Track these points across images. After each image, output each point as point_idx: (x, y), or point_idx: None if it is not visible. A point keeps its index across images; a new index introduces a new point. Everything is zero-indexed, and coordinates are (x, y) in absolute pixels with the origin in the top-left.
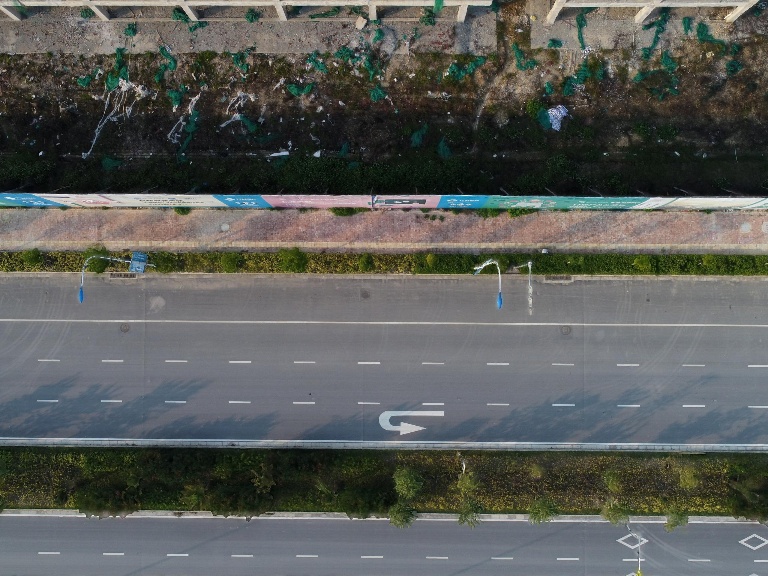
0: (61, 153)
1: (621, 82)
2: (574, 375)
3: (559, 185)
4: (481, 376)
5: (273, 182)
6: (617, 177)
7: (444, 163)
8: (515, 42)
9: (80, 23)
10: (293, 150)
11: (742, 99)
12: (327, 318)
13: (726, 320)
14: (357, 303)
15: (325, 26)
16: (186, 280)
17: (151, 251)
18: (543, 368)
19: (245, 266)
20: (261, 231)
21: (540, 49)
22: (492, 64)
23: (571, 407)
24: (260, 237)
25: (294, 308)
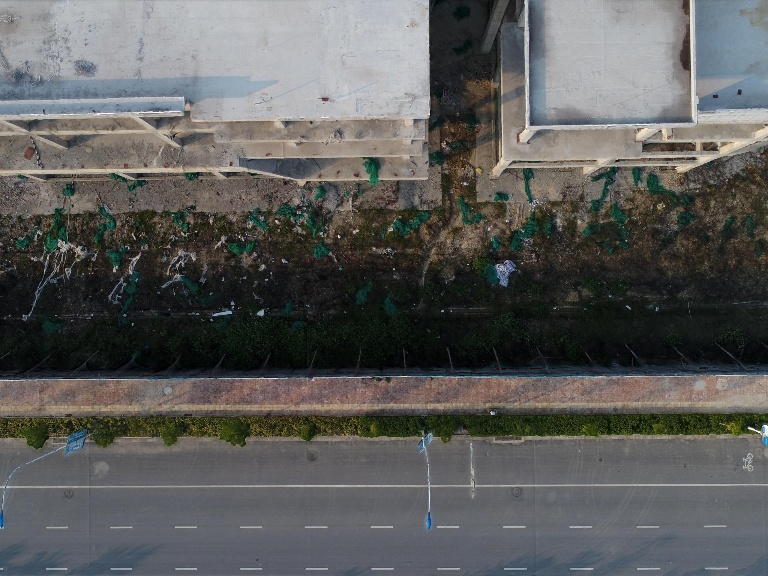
0: (1, 315)
1: (570, 236)
2: (526, 538)
3: (506, 348)
4: (431, 540)
5: (215, 345)
6: (566, 336)
7: (389, 322)
8: (461, 195)
9: (17, 184)
10: (236, 309)
11: (694, 252)
12: (273, 482)
13: (681, 479)
14: (303, 466)
15: (266, 183)
16: (130, 444)
17: (94, 416)
18: (494, 531)
19: (189, 431)
20: (204, 394)
21: (486, 203)
22: (437, 219)
23: (523, 571)
24: (204, 400)
25: (240, 472)
